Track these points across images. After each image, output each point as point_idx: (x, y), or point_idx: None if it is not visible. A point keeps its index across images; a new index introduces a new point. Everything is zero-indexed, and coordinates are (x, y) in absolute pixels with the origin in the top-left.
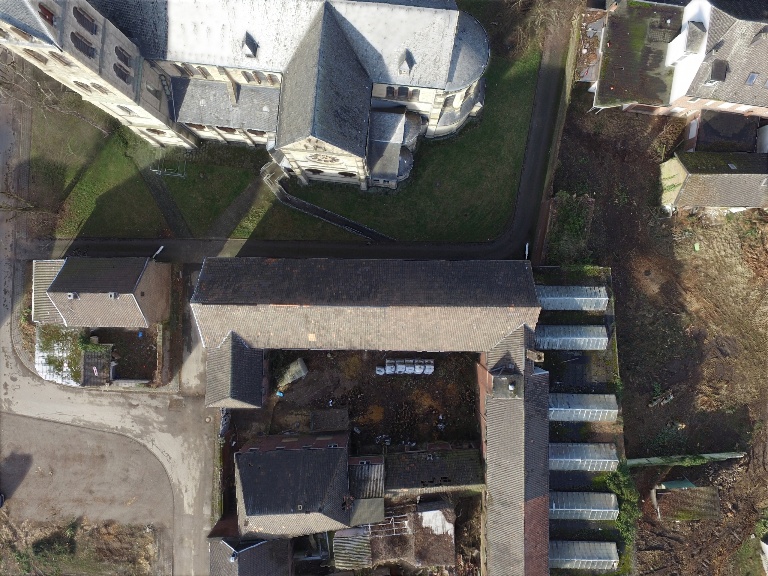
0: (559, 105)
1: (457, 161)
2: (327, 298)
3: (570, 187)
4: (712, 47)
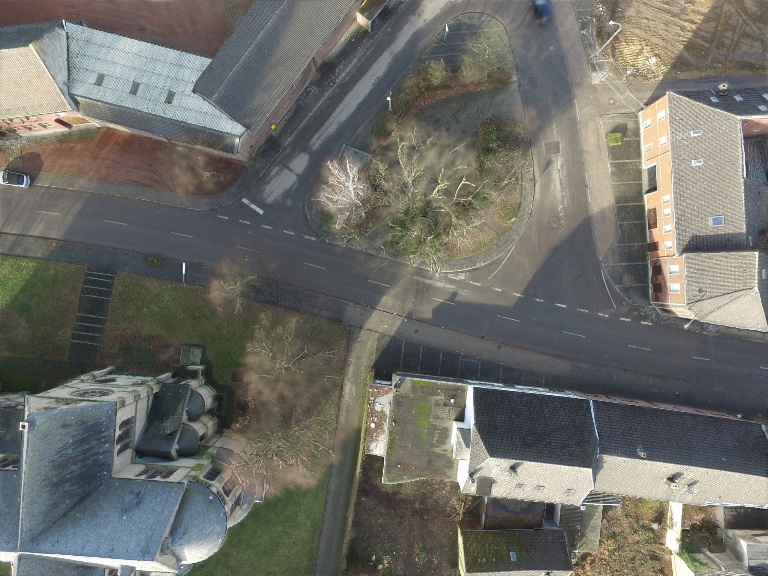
0: (356, 467)
1: (253, 530)
2: None
3: (369, 548)
4: (473, 470)
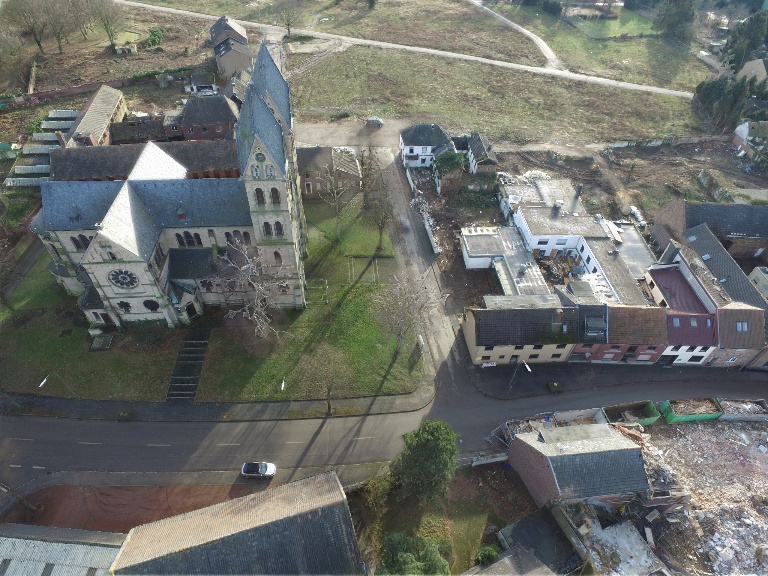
0: None
1: None
2: (174, 146)
3: None
4: None
